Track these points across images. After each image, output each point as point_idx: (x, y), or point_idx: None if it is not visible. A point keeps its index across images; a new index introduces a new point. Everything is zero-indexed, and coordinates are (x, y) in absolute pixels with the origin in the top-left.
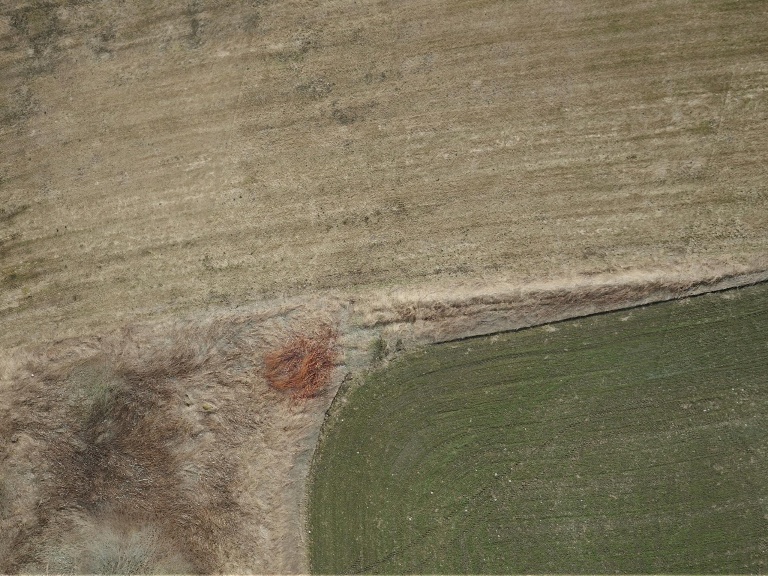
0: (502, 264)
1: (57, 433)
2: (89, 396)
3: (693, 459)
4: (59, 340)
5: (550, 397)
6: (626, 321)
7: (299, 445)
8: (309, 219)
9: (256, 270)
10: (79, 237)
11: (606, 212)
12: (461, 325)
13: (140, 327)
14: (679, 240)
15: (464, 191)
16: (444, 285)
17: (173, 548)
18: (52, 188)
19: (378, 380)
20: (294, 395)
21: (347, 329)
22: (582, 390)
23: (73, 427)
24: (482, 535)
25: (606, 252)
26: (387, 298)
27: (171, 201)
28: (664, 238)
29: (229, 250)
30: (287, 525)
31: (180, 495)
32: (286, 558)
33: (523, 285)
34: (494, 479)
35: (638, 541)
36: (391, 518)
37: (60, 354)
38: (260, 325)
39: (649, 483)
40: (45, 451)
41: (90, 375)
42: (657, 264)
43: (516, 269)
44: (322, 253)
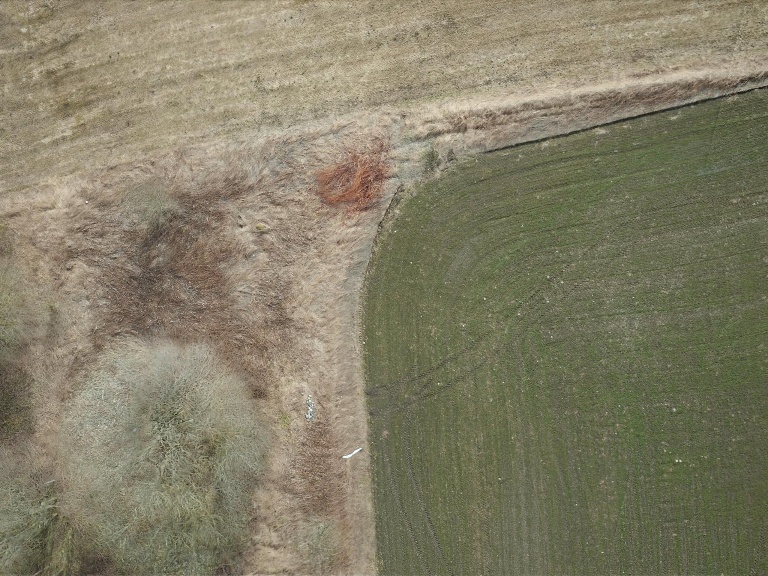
0: (552, 71)
1: (112, 259)
2: (143, 221)
3: (743, 252)
4: (113, 166)
5: (601, 198)
6: (675, 120)
7: (353, 257)
8: (359, 37)
9: (307, 90)
10: (132, 63)
11: (654, 15)
12: (512, 132)
13: (193, 150)
14: (726, 39)
15: (513, 1)
16: (494, 94)
17: (228, 369)
18: (104, 15)
19: (430, 190)
20: (347, 208)
21: (399, 142)
22: (633, 189)
23: (127, 252)
24: (535, 337)
25: (654, 54)
26: (438, 110)
27: (223, 24)
28: (712, 38)
29: (280, 71)
30: (342, 337)
31: (234, 316)
32: (341, 369)
33: (573, 89)
34: (546, 281)
35: (689, 335)
36: (445, 325)
37: (114, 179)
38: (312, 143)
39: (700, 277)
40: (100, 277)
41: (144, 200)
42: (705, 63)
43: (566, 75)
44: (373, 70)
